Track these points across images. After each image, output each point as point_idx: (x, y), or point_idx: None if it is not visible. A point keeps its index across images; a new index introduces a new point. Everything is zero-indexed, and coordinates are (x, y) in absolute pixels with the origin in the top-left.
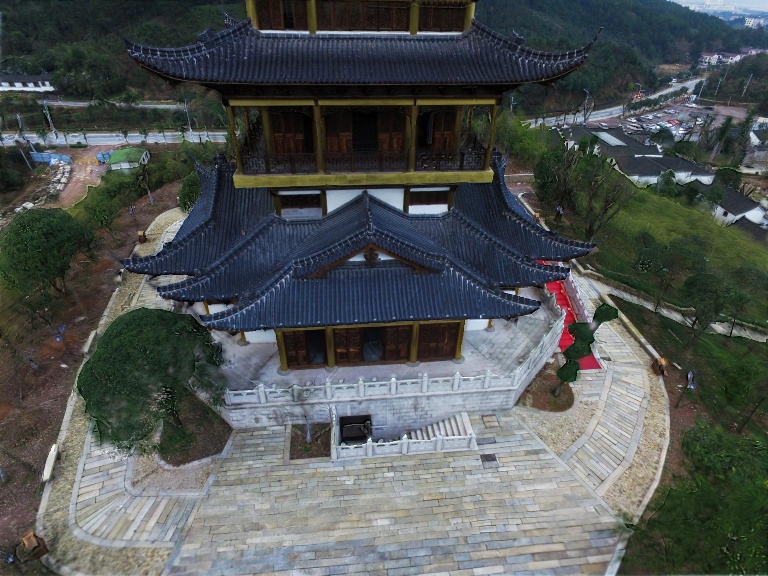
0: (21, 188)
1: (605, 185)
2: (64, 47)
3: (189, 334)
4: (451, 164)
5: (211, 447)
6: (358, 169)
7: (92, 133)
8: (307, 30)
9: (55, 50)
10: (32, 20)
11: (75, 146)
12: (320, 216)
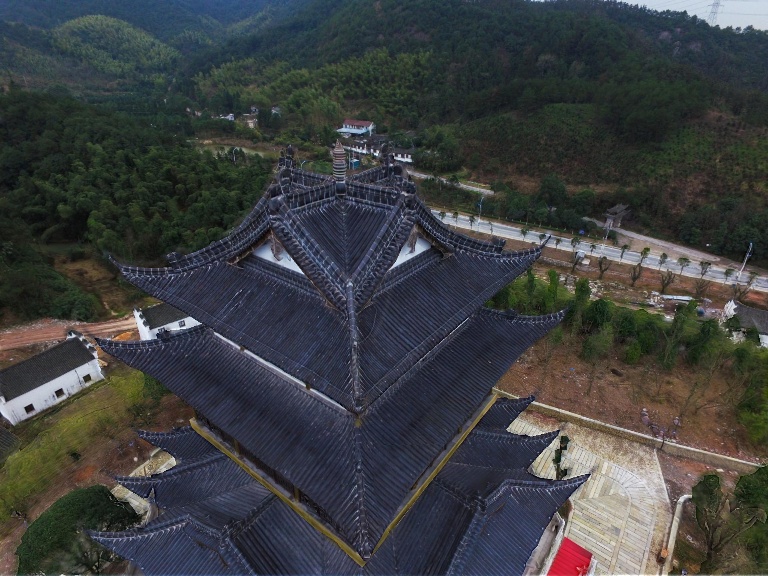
0: None
1: None
2: (436, 128)
3: None
4: (329, 519)
5: None
6: (261, 468)
7: None
8: (240, 346)
9: (429, 130)
10: (428, 105)
11: None
12: None
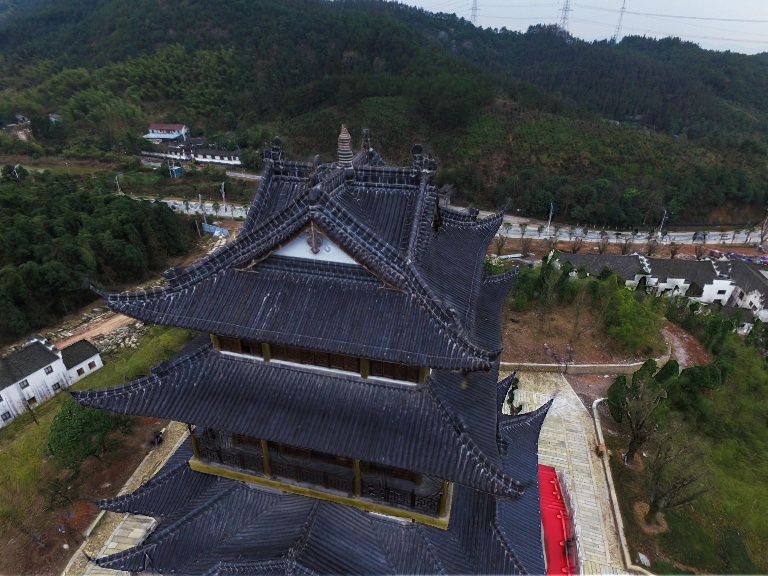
0: (187, 254)
1: (717, 408)
2: (258, 128)
3: None
4: (401, 500)
5: None
6: (304, 480)
7: None
8: (262, 357)
9: (251, 130)
10: (243, 103)
11: (237, 219)
12: (281, 492)
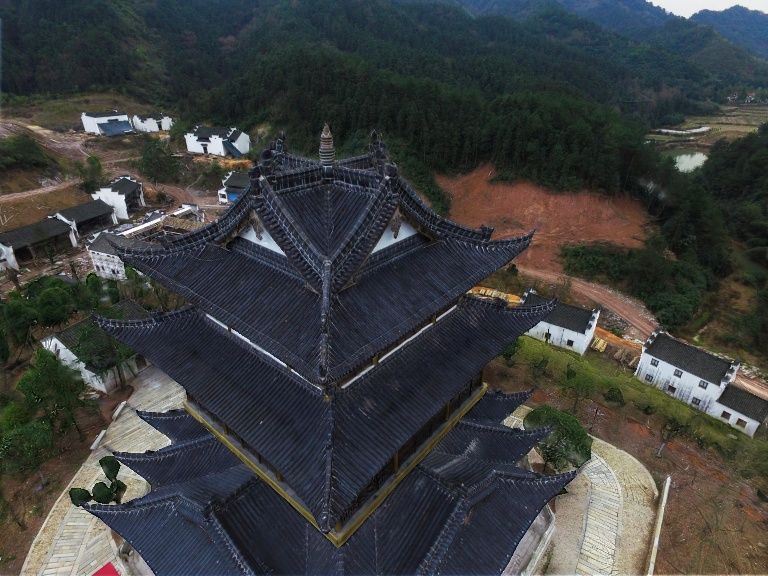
0: None
1: None
2: None
3: None
4: None
5: None
6: None
7: None
8: None
9: None
10: None
11: None
12: None
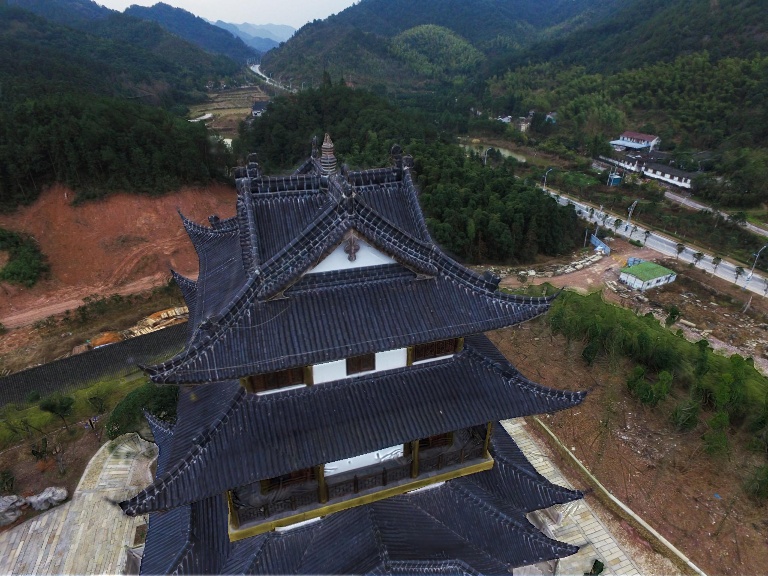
0: None
1: None
2: (742, 152)
3: None
4: None
5: None
6: None
7: (665, 237)
8: None
9: (731, 153)
10: (744, 121)
11: (633, 242)
12: None
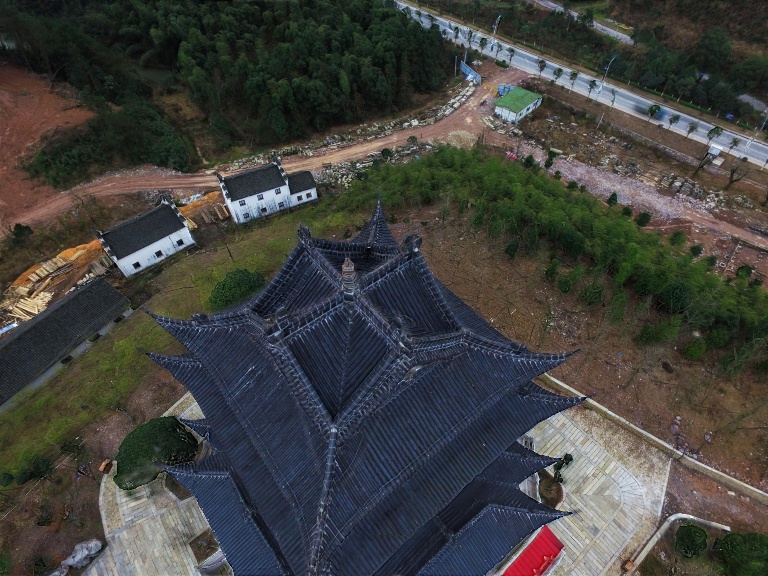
0: None
1: None
2: None
3: (161, 463)
4: None
5: (182, 493)
6: None
7: (526, 50)
8: None
9: None
10: None
11: (499, 63)
12: None
